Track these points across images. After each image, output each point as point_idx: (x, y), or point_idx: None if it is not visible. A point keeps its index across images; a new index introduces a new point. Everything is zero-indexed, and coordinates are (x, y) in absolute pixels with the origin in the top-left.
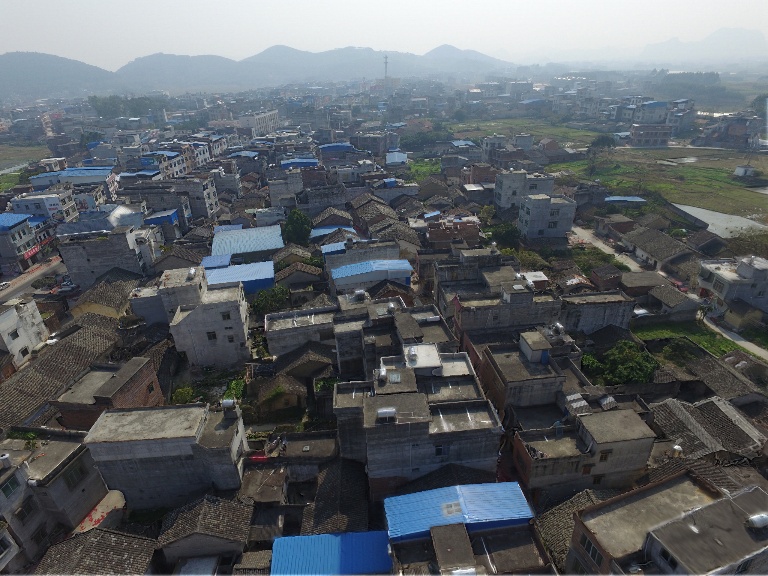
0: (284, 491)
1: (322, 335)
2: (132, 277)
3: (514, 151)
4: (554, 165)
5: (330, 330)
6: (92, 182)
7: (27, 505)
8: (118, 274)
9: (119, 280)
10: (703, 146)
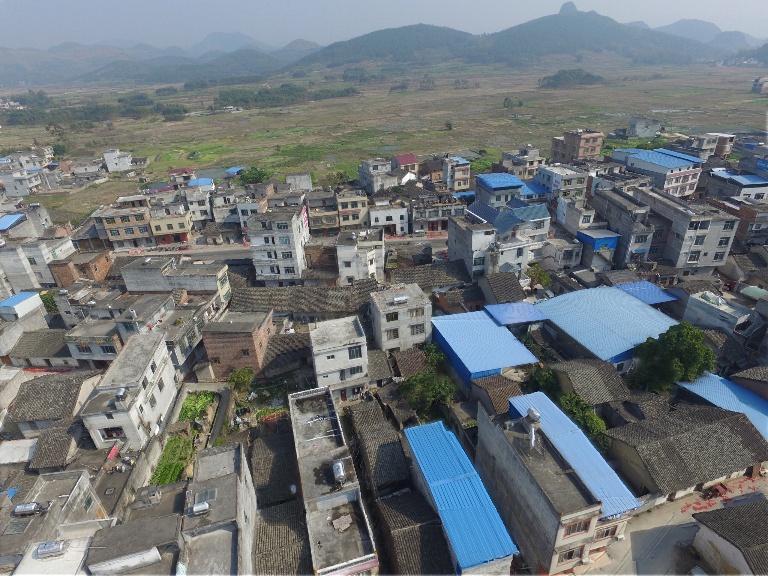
0: None
1: None
2: (460, 276)
3: None
4: None
5: None
6: (653, 171)
7: None
8: (454, 266)
9: (445, 271)
10: None
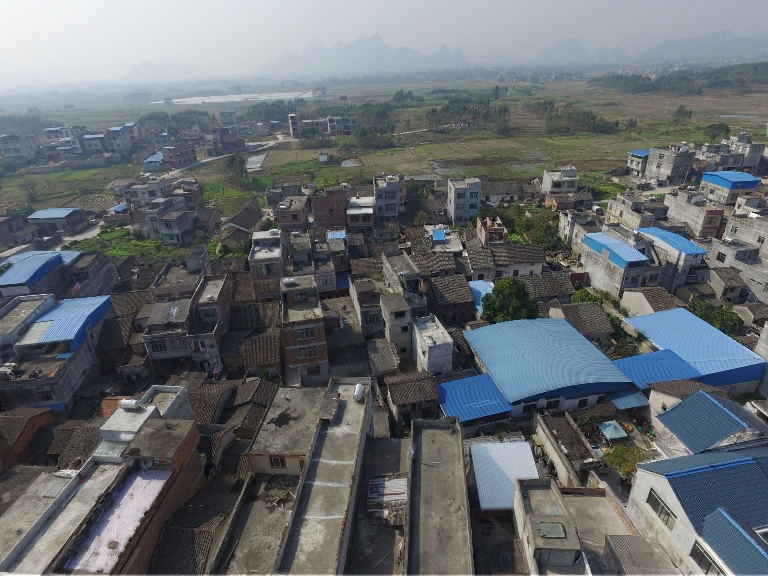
0: None
1: None
2: None
3: (197, 189)
4: (207, 196)
5: None
6: None
7: None
8: None
9: None
10: (220, 155)
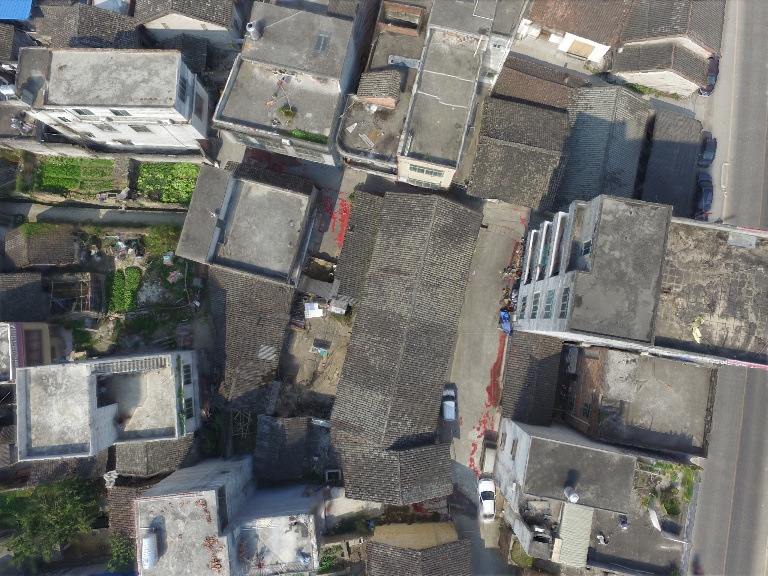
0: None
1: None
2: None
3: None
4: None
5: None
6: None
7: None
8: None
9: None
10: None
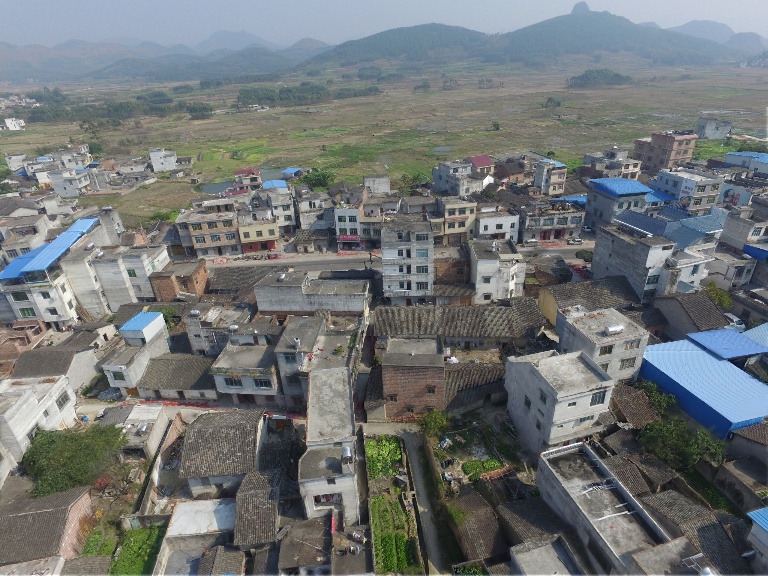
0: (300, 572)
1: (593, 544)
2: (626, 295)
3: None
4: None
5: (604, 554)
6: None
7: (295, 377)
8: (617, 284)
9: (608, 290)
10: None
